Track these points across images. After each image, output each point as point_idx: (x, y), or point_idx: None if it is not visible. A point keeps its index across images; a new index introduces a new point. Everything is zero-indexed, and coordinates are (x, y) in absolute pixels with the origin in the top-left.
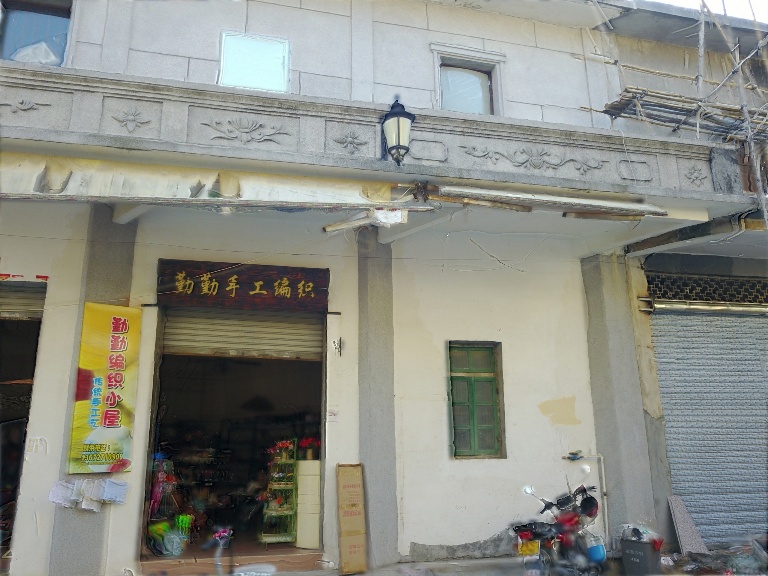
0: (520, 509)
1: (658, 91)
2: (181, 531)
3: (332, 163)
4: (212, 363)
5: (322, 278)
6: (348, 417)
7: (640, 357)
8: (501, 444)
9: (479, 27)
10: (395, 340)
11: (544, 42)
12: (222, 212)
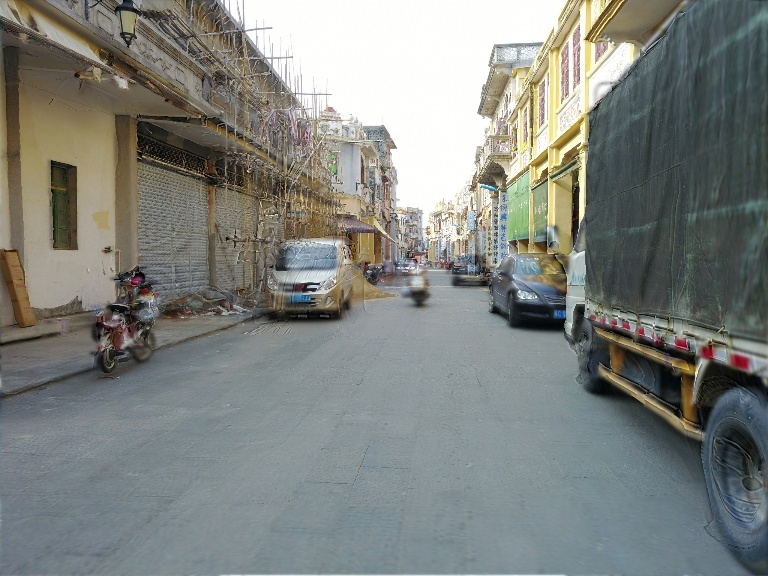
0: (83, 283)
1: None
2: None
3: (82, 22)
4: None
5: None
6: (2, 213)
7: None
8: (70, 240)
9: None
10: (20, 153)
11: None
12: (19, 37)
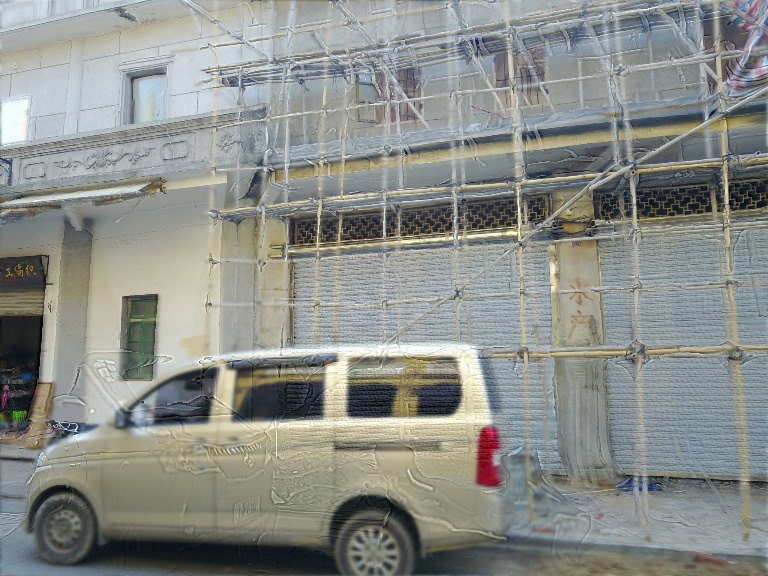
0: None
1: (228, 65)
2: (14, 420)
3: None
4: (12, 320)
5: (37, 262)
6: (52, 352)
7: (260, 299)
8: None
9: (157, 37)
10: (90, 299)
11: (209, 31)
12: None
